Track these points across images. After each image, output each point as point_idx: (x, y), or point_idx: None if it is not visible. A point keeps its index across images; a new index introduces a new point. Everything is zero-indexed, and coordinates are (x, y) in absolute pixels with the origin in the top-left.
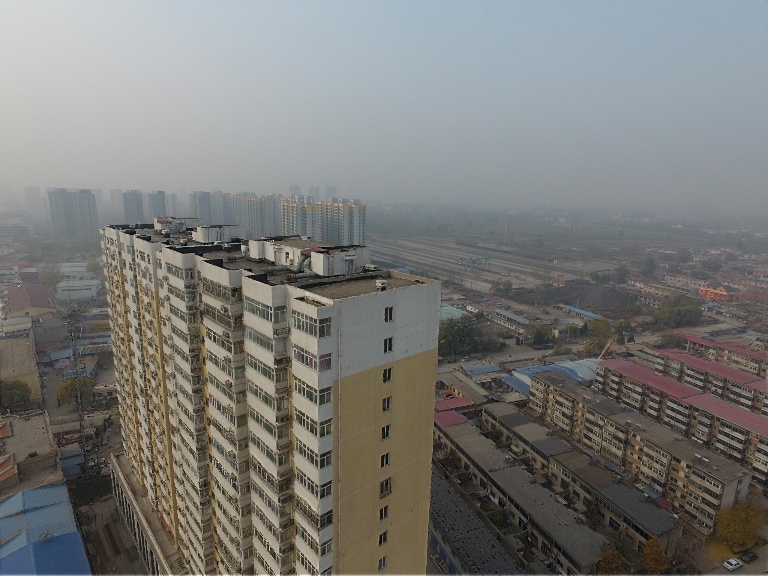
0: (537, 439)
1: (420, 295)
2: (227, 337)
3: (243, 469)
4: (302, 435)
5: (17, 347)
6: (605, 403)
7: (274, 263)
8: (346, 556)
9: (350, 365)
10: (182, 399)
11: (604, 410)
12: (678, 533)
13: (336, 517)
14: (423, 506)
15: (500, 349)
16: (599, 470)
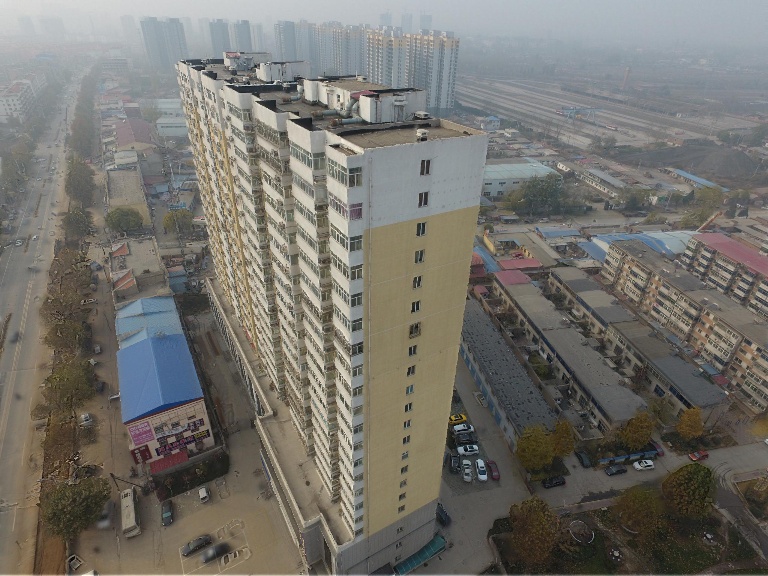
0: (600, 306)
1: (463, 148)
2: (278, 181)
3: (298, 301)
4: (337, 277)
5: (128, 179)
6: (685, 278)
7: (327, 106)
8: (376, 379)
9: (381, 216)
10: (251, 236)
11: (681, 285)
12: (724, 407)
13: (366, 348)
14: (452, 350)
15: (585, 213)
16: (658, 342)
